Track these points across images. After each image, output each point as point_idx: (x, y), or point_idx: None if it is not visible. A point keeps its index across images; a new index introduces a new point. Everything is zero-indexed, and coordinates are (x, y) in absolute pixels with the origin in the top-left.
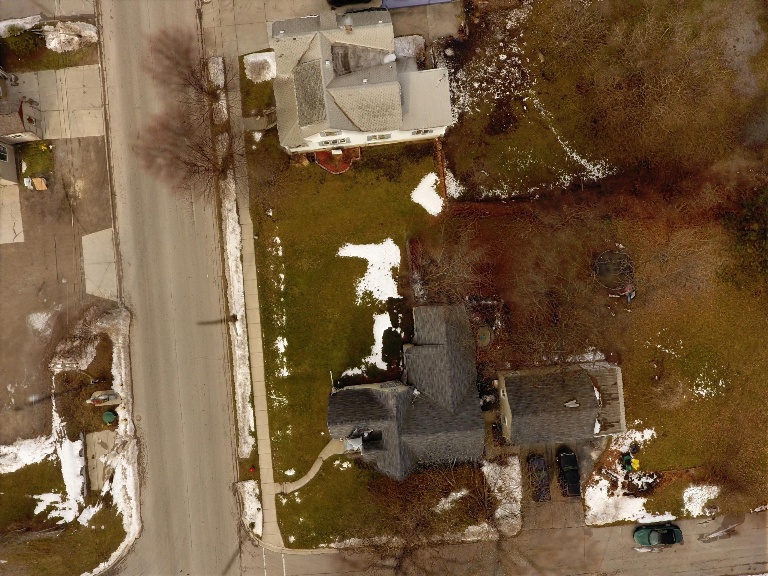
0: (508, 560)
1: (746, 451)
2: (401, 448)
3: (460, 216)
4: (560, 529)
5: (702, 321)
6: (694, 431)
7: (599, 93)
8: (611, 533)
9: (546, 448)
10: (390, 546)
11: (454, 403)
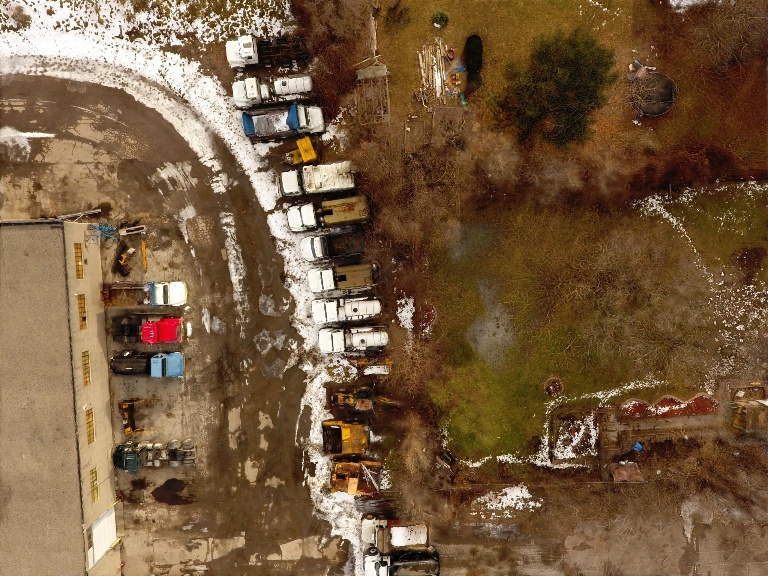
0: None
1: None
2: None
3: None
4: None
5: (556, 35)
6: None
7: (645, 286)
8: None
9: None
10: None
11: None
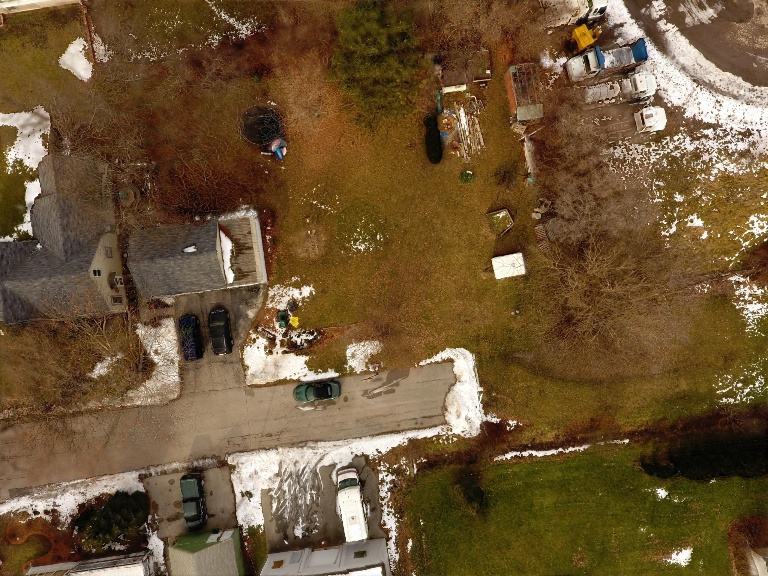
0: (170, 424)
1: (408, 305)
2: (7, 296)
3: (110, 80)
4: (221, 390)
5: (358, 175)
6: (354, 286)
7: None
8: (274, 393)
9: (201, 308)
10: (49, 414)
11: (67, 252)
